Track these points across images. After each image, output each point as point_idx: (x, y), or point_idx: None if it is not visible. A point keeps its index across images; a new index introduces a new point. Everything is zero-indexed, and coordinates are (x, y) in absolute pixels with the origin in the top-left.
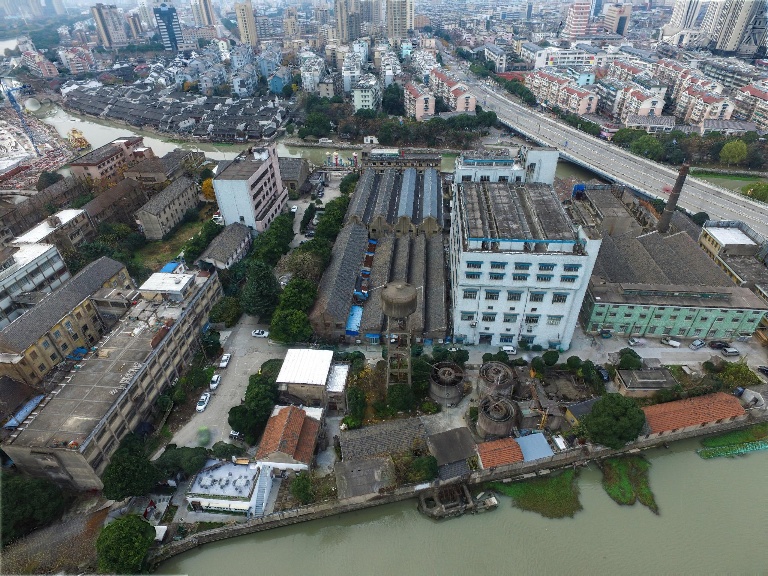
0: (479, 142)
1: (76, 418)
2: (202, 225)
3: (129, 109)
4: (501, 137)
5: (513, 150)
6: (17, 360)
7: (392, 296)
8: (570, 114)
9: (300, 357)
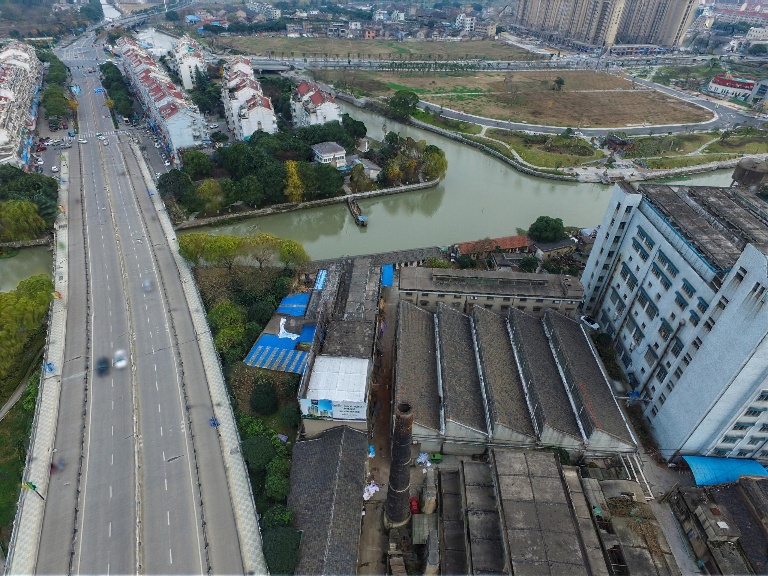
0: None
1: None
2: None
3: None
4: None
5: None
6: None
7: (755, 160)
8: None
9: None
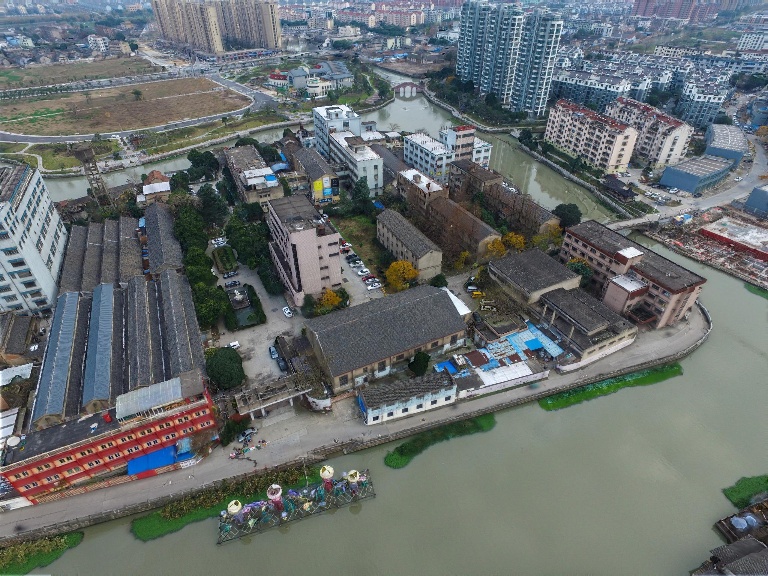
0: None
1: None
2: None
3: None
4: None
5: None
6: None
7: (85, 143)
8: None
9: (161, 188)
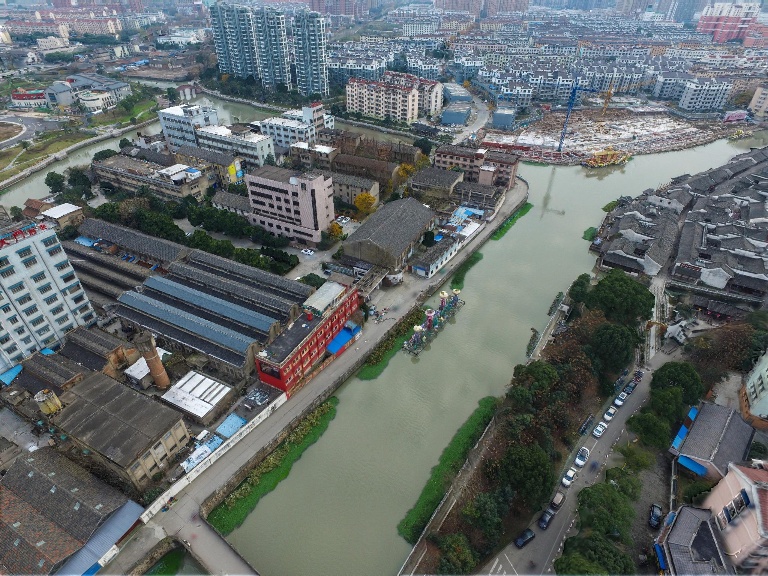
0: None
1: None
2: None
3: (728, 167)
4: None
5: None
6: (174, 153)
7: None
8: None
9: (69, 209)
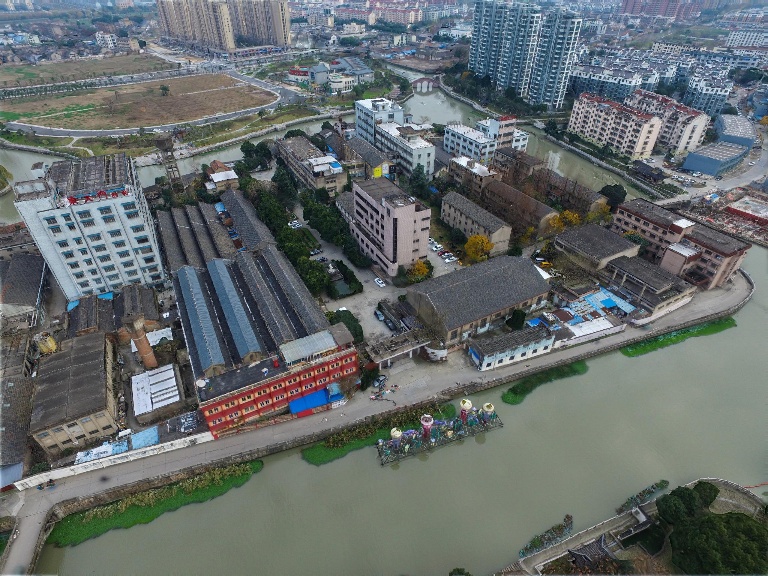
0: None
1: (290, 142)
2: (437, 239)
3: None
4: None
5: None
6: None
7: (164, 133)
8: None
9: (229, 176)
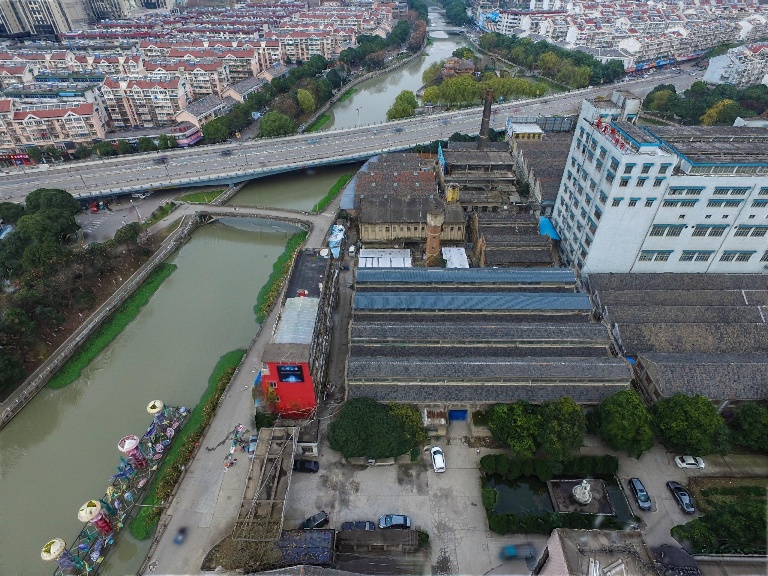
0: (145, 233)
1: None
2: None
3: None
4: (99, 218)
5: (197, 209)
6: None
7: None
8: (82, 145)
9: None
